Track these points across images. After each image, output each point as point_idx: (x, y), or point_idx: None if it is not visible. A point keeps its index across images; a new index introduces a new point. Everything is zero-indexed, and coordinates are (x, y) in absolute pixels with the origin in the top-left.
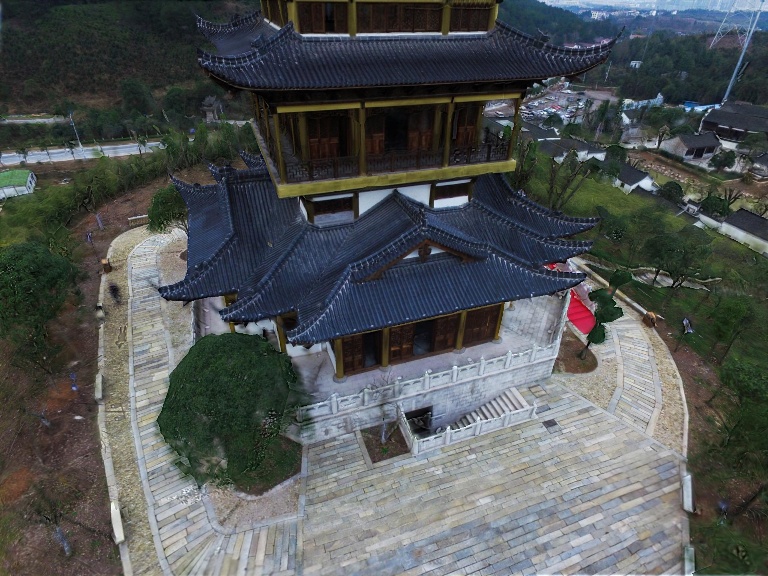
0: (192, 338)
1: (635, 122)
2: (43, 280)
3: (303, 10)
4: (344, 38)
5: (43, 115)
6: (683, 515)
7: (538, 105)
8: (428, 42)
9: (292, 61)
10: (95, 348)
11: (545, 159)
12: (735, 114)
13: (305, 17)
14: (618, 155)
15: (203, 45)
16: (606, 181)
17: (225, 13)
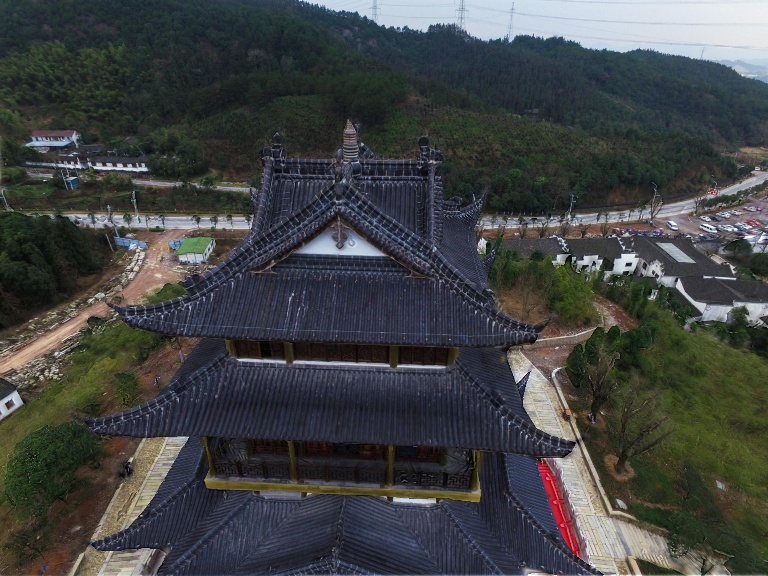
0: (148, 556)
1: None
2: (54, 471)
3: (240, 341)
4: (280, 365)
5: (244, 184)
6: None
7: (729, 217)
8: (372, 373)
9: (213, 394)
10: (101, 513)
11: (670, 342)
12: None
13: (242, 346)
14: None
15: (380, 134)
16: None
17: (406, 106)
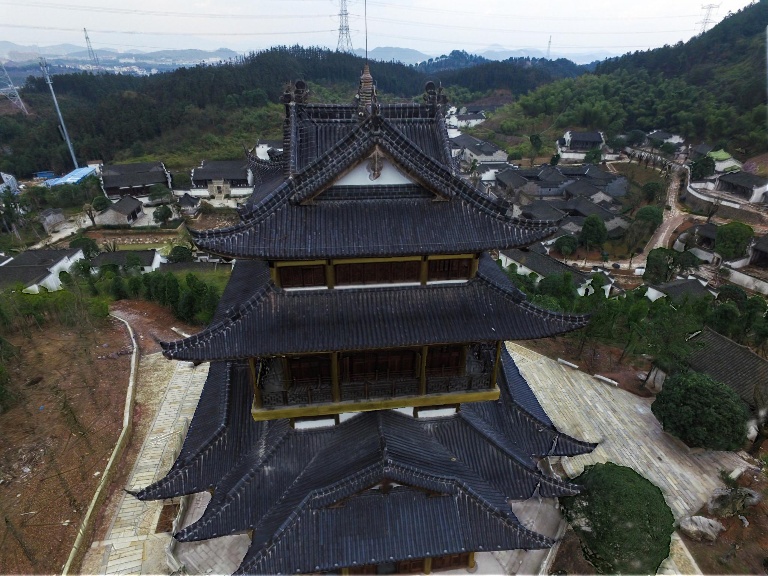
0: None
1: (29, 209)
2: None
3: None
4: None
5: None
6: (577, 371)
7: None
8: None
9: None
10: None
11: None
12: (123, 175)
13: None
14: (89, 246)
15: None
16: (133, 273)
17: None
